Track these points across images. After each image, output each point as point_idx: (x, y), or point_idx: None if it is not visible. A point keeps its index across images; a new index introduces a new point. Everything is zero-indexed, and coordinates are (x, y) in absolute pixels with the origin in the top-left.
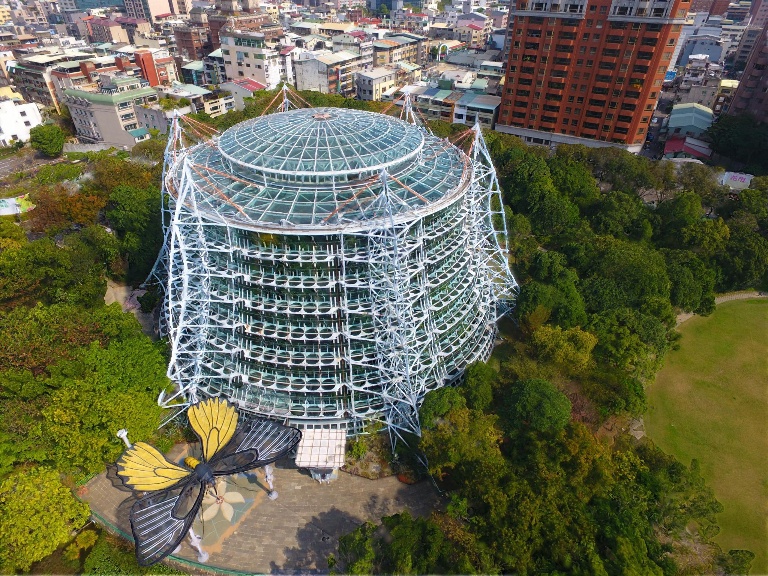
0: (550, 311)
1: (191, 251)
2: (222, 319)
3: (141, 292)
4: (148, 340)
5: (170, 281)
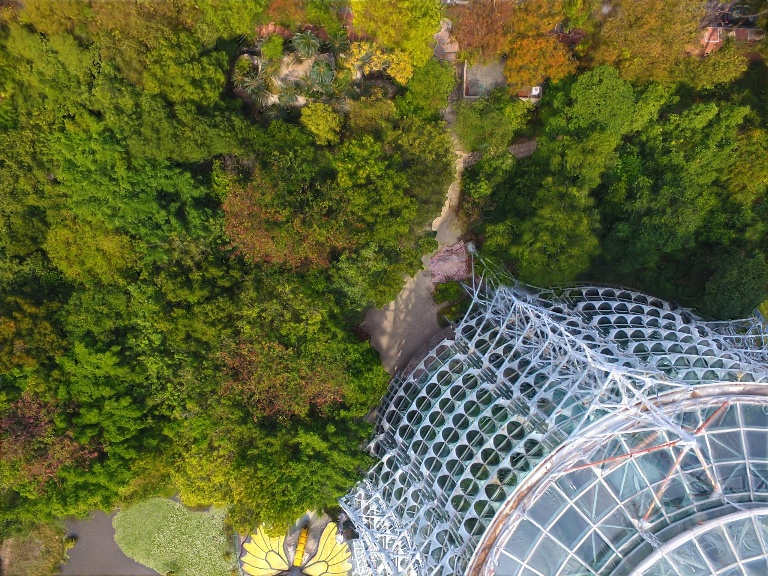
0: None
1: (443, 537)
2: (404, 567)
3: (458, 263)
4: (356, 463)
5: (375, 575)
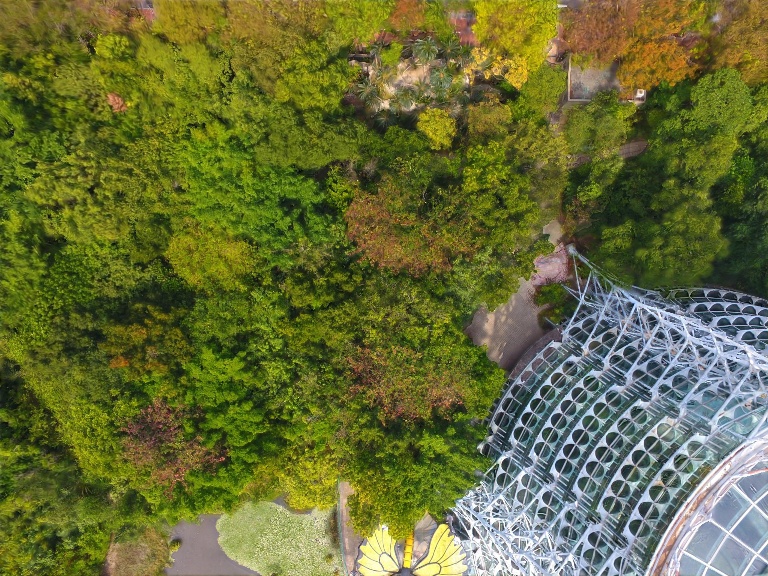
0: None
1: (595, 539)
2: None
3: (559, 265)
4: (478, 465)
5: None
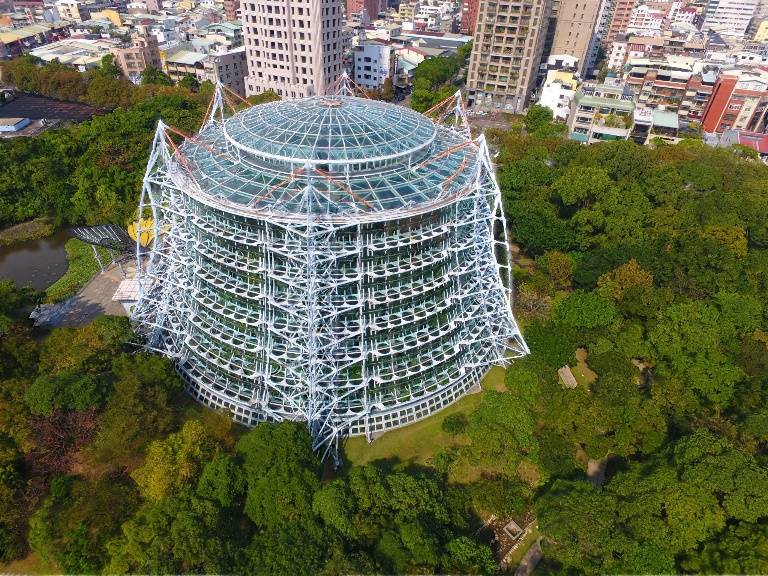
0: (219, 434)
1: None
2: None
3: None
4: None
5: None
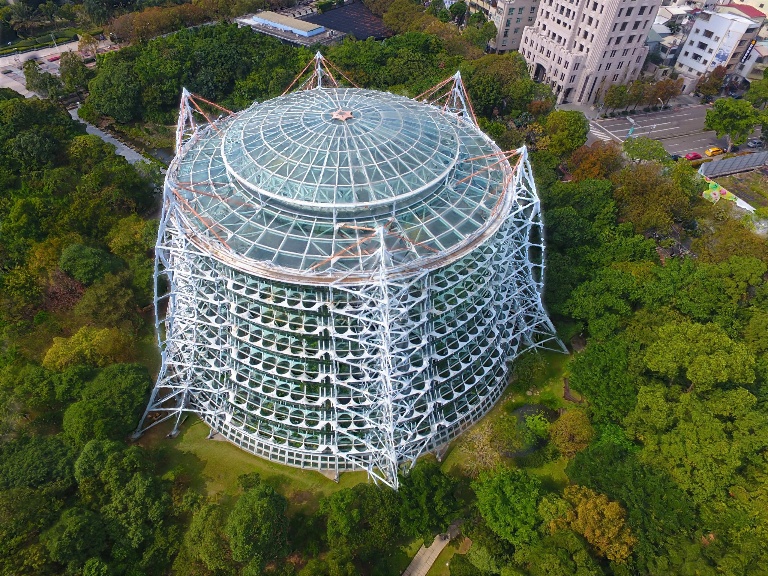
0: (97, 351)
1: None
2: None
3: None
4: None
5: None
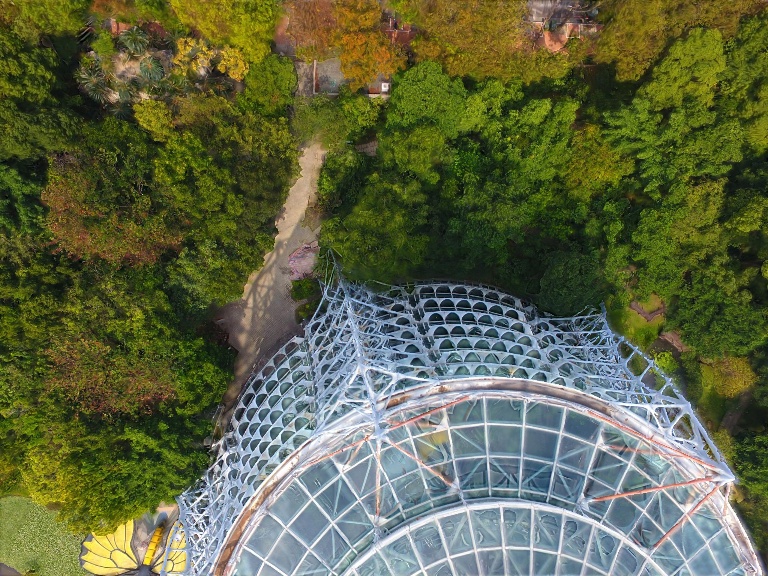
0: None
1: None
2: None
3: (314, 260)
4: (186, 461)
5: (162, 574)
